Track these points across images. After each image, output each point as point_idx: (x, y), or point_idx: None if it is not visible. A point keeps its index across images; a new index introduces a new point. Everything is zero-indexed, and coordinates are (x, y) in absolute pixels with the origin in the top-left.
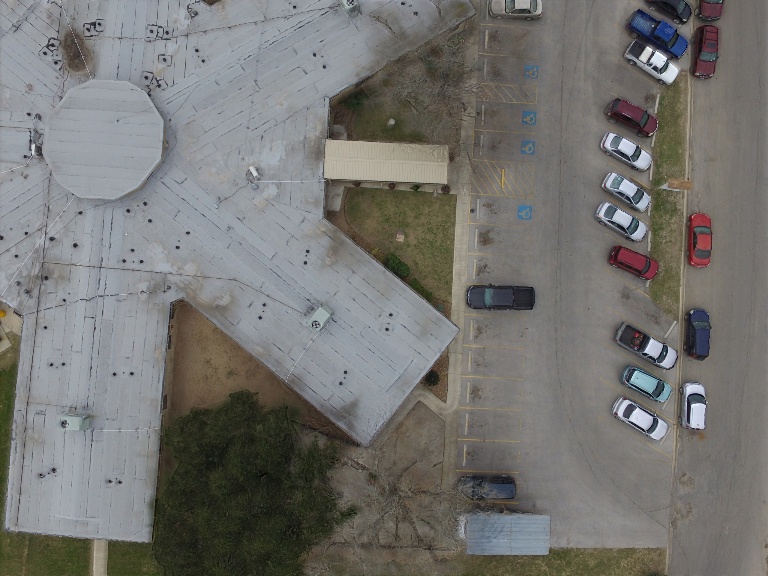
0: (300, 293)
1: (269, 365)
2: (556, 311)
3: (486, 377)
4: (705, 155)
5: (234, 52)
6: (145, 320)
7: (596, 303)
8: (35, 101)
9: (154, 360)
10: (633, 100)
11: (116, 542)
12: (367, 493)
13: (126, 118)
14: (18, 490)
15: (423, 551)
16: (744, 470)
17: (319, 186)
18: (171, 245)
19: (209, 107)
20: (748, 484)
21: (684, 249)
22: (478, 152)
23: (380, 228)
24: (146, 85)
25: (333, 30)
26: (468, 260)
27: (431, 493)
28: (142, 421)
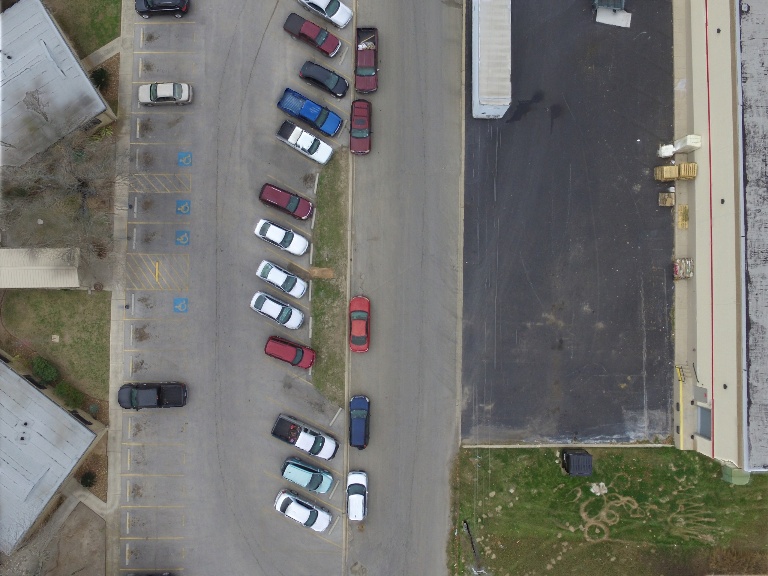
0: None
1: None
2: (216, 404)
3: (146, 475)
4: (368, 234)
5: None
6: None
7: (257, 394)
8: None
9: None
10: (291, 181)
11: None
12: None
13: None
14: None
15: None
16: (417, 557)
17: None
18: None
19: None
20: (422, 571)
21: (348, 333)
22: (132, 246)
23: (36, 329)
24: None
25: None
26: (124, 357)
27: None
28: None
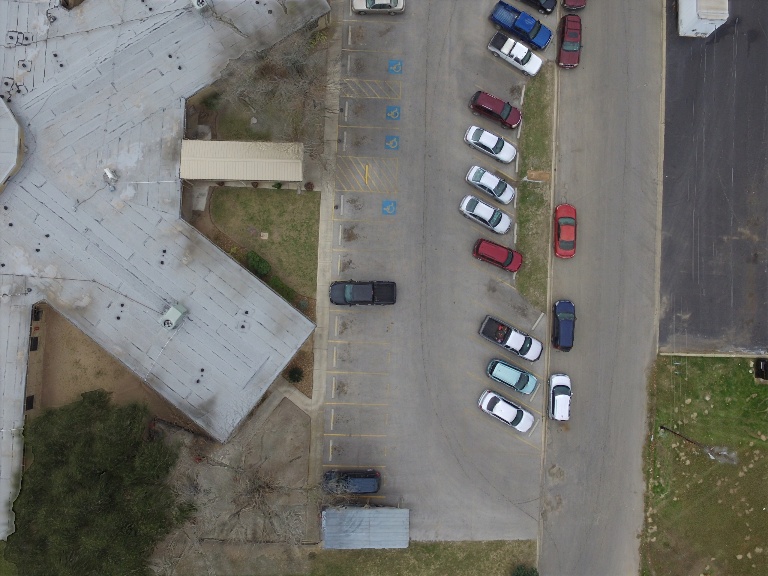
0: (156, 293)
1: (128, 364)
2: (421, 305)
3: (351, 372)
4: (572, 145)
5: (91, 56)
6: (7, 322)
7: (462, 296)
8: None
9: (17, 362)
10: (498, 92)
11: None
12: (233, 489)
13: None
14: None
15: (291, 546)
16: (614, 461)
17: (175, 186)
18: (32, 248)
19: (67, 111)
20: (618, 475)
21: (551, 240)
22: (342, 148)
23: (245, 226)
24: (7, 91)
25: (188, 31)
26: (332, 256)
27: (289, 488)
28: (6, 422)
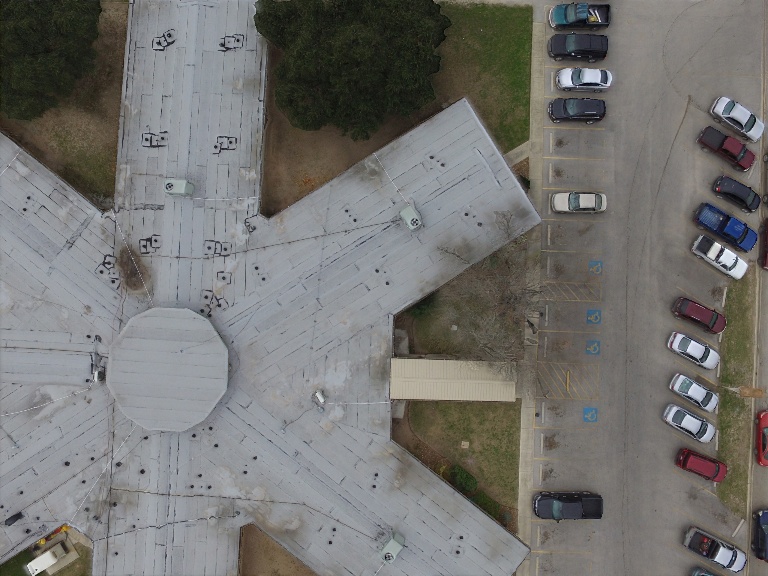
0: (370, 518)
1: None
2: (623, 514)
3: None
4: None
5: (295, 269)
6: (215, 545)
7: (663, 504)
8: (94, 323)
9: None
10: (700, 294)
11: None
12: None
13: (190, 348)
14: None
15: None
16: None
17: (386, 407)
18: (238, 469)
19: (271, 327)
20: None
21: (752, 446)
22: (542, 354)
23: (445, 435)
24: (206, 304)
25: (395, 244)
26: (534, 465)
27: None
28: None
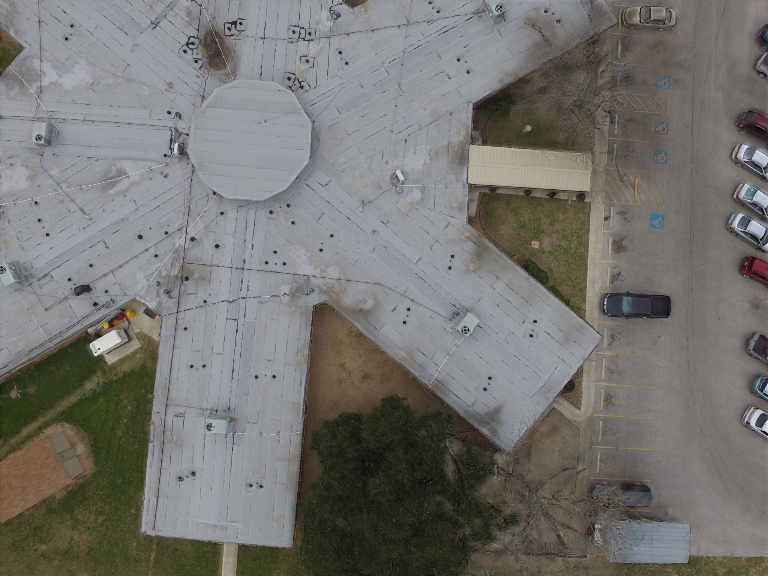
0: (445, 298)
1: (412, 370)
2: (688, 320)
3: (619, 385)
4: None
5: (378, 55)
6: (287, 323)
7: (727, 313)
8: (175, 99)
9: (296, 363)
10: (762, 112)
11: (246, 547)
12: (503, 500)
13: (274, 119)
14: (155, 493)
15: (556, 558)
16: None
17: (463, 191)
18: (314, 248)
19: (353, 110)
20: None
21: None
22: (612, 160)
23: (515, 234)
24: (288, 86)
25: (477, 36)
26: (602, 268)
27: (574, 500)
28: (284, 425)
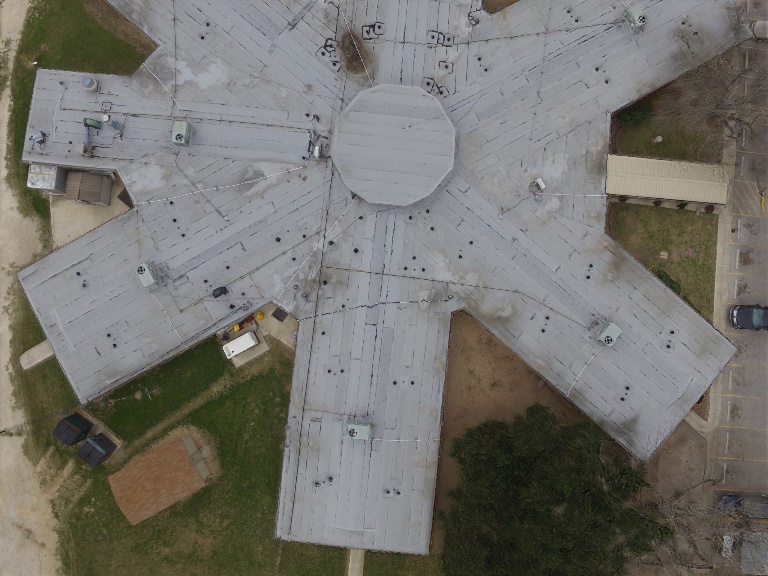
0: (585, 307)
1: (550, 379)
2: None
3: (745, 397)
4: None
5: (517, 63)
6: (426, 329)
7: None
8: (314, 102)
9: (434, 370)
10: None
11: (373, 553)
12: None
13: (418, 124)
14: (291, 498)
15: (681, 569)
16: None
17: (601, 201)
18: (452, 254)
19: (492, 117)
20: None
21: None
22: (739, 173)
23: (644, 244)
24: (427, 91)
25: (615, 46)
26: (729, 280)
27: (708, 512)
28: (421, 431)
